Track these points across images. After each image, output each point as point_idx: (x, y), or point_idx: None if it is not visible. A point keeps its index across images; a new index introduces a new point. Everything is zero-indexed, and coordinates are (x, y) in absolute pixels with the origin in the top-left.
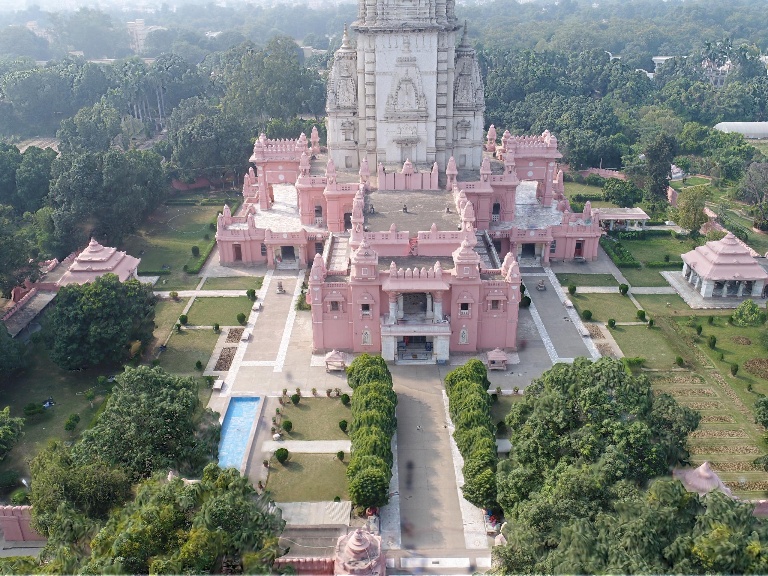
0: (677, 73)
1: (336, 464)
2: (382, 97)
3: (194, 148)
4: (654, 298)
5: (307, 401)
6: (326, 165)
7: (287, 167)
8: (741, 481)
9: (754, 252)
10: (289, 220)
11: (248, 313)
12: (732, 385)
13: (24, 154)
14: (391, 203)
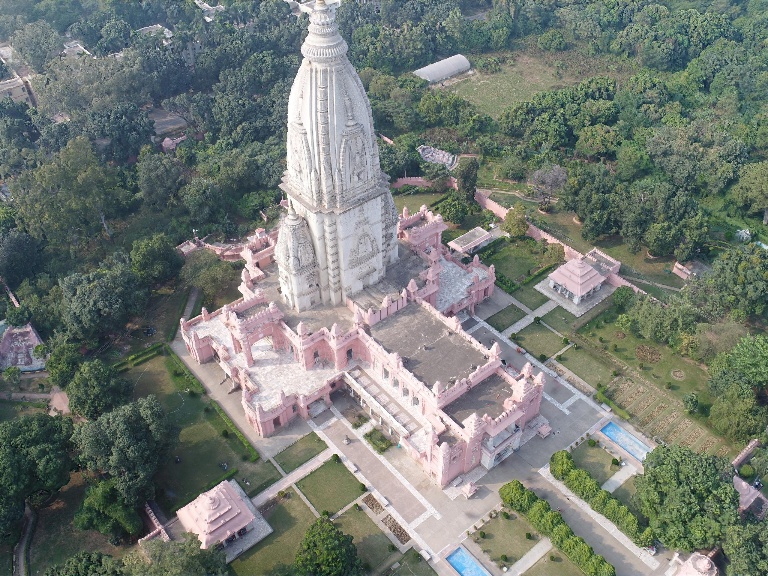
0: (359, 19)
1: (552, 564)
2: (346, 253)
3: (101, 318)
4: (553, 317)
5: (485, 530)
6: (286, 306)
7: (265, 327)
8: (700, 447)
9: (575, 251)
10: (289, 370)
11: (353, 477)
12: (646, 377)
13: (4, 439)
14: (402, 341)
